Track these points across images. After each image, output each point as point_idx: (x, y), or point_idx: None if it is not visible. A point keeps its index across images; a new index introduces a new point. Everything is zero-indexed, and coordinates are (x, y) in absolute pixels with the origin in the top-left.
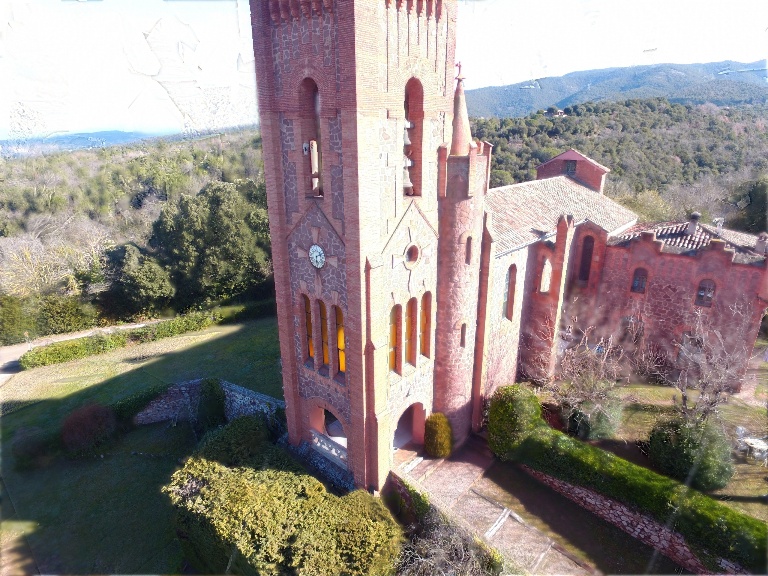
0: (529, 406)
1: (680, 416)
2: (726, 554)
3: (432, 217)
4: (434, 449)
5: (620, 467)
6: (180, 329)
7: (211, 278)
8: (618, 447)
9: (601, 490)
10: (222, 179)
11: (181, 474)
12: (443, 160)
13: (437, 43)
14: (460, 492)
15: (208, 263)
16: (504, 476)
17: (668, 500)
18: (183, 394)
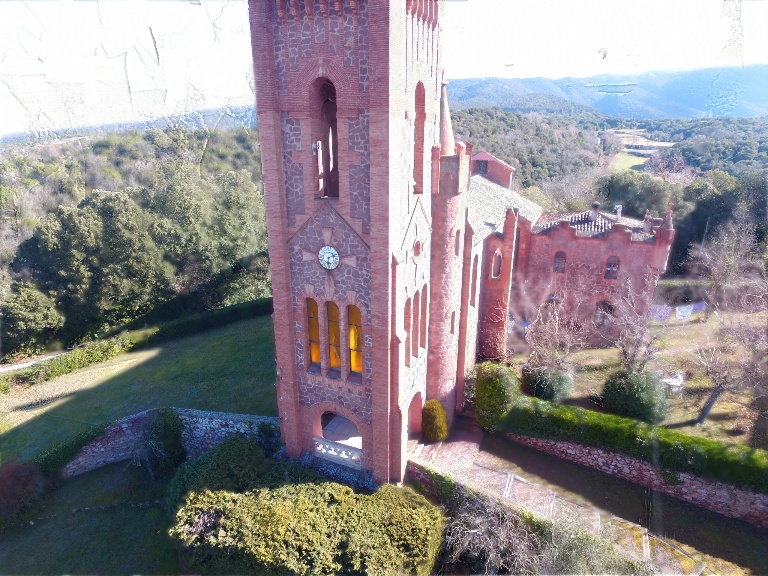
0: (512, 379)
1: (624, 368)
2: (683, 469)
3: (428, 213)
4: (434, 434)
5: (593, 417)
6: (81, 362)
7: (110, 300)
8: (577, 403)
9: (580, 440)
10: (85, 189)
11: (186, 512)
12: (436, 159)
13: (433, 50)
14: (467, 468)
15: (107, 283)
16: (495, 446)
17: (637, 436)
18: (124, 432)
